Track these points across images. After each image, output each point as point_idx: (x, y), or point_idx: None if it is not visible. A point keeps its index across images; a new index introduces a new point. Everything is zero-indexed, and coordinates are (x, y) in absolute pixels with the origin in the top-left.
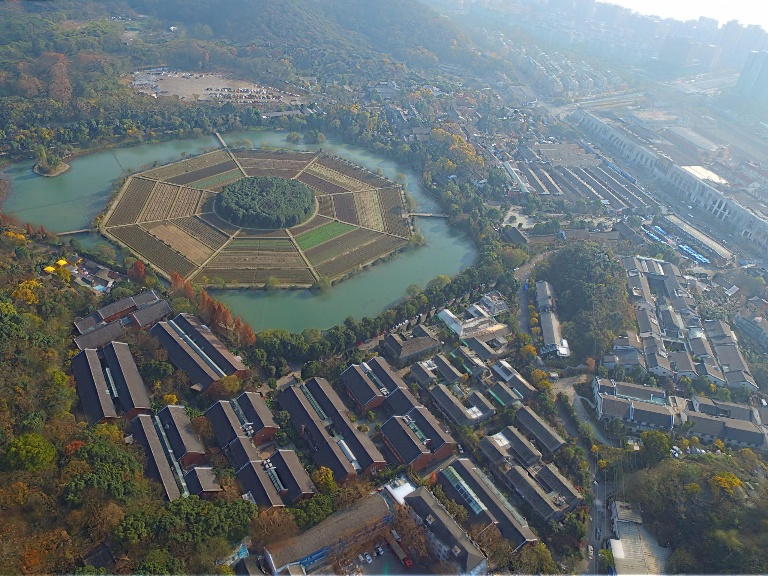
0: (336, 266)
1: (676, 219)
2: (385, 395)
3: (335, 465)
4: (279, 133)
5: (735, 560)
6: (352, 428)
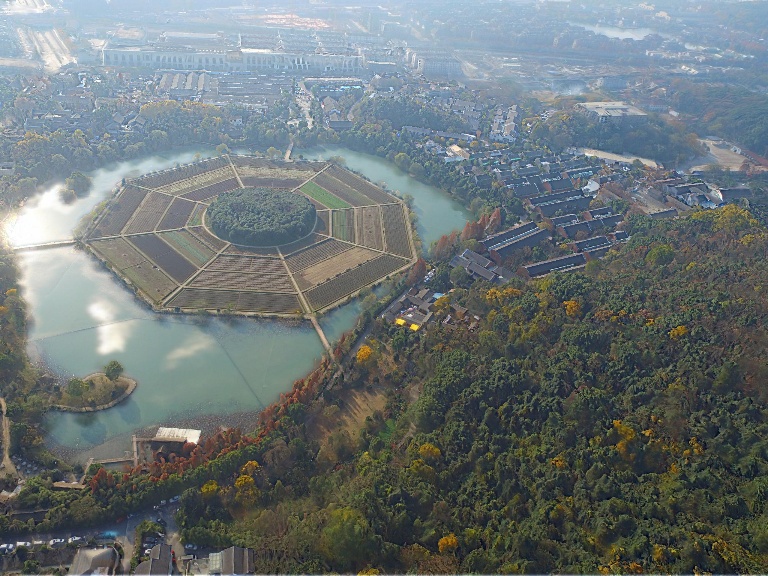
0: (376, 195)
1: (312, 78)
2: None
3: (588, 200)
4: (37, 206)
5: (598, 129)
6: None
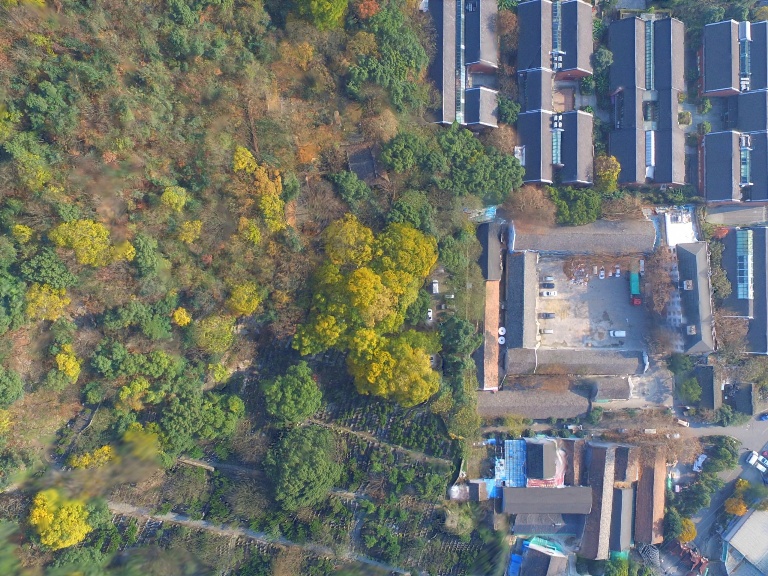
0: None
1: None
2: (742, 90)
3: (628, 162)
4: None
5: None
6: (674, 122)
